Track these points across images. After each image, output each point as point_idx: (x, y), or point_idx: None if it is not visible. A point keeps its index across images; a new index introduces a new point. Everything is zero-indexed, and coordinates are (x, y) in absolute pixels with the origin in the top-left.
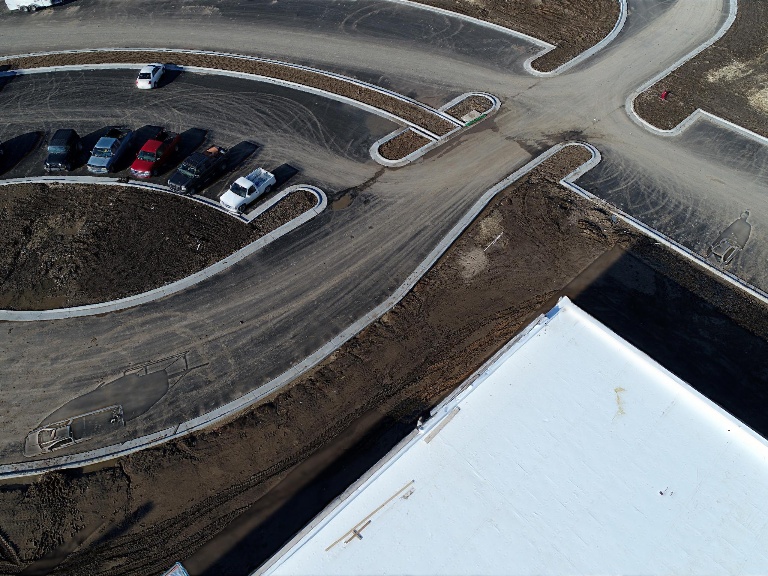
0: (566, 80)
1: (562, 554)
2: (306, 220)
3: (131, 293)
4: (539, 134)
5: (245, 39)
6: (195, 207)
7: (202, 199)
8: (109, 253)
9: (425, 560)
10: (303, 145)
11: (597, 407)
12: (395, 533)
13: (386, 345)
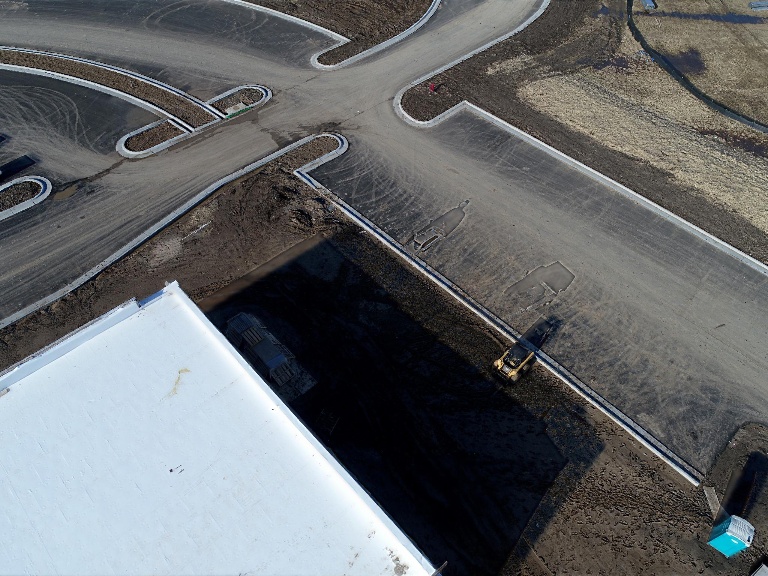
0: (347, 73)
1: (36, 530)
2: (20, 210)
3: None
4: (296, 126)
5: (41, 34)
6: None
7: None
8: None
9: None
10: (52, 137)
11: (151, 388)
12: None
13: (39, 332)
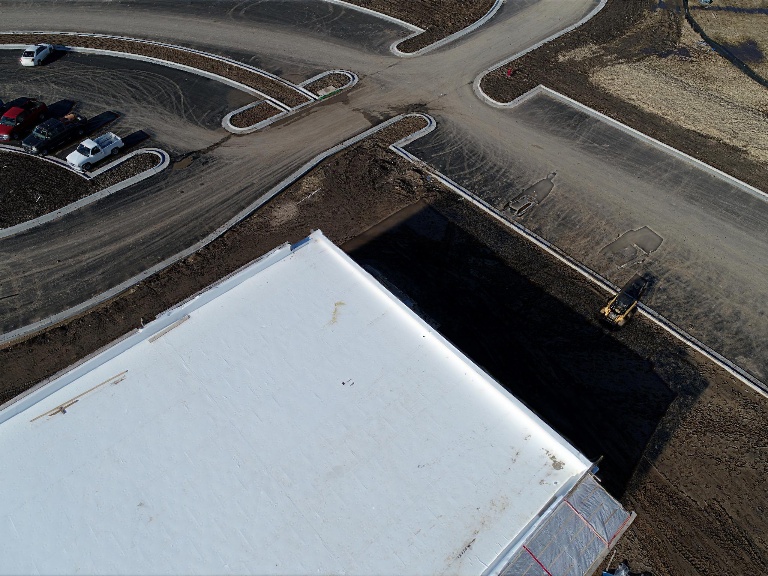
0: (426, 60)
1: (236, 428)
2: (144, 178)
3: None
4: (385, 106)
5: (136, 24)
6: (45, 166)
7: (53, 159)
8: None
9: (114, 430)
10: (162, 115)
11: (313, 317)
12: (96, 410)
13: (182, 280)
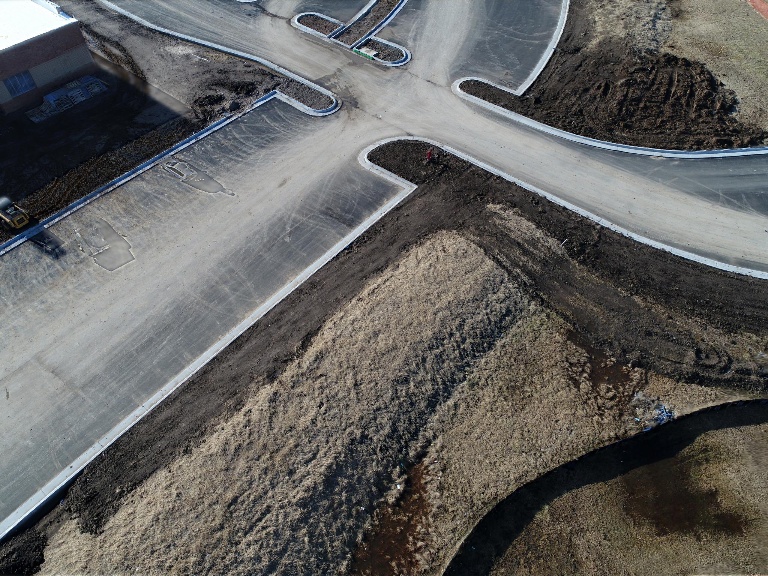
0: (451, 102)
1: None
2: None
3: None
4: (348, 84)
5: None
6: None
7: None
8: None
9: None
10: None
11: None
12: None
13: None
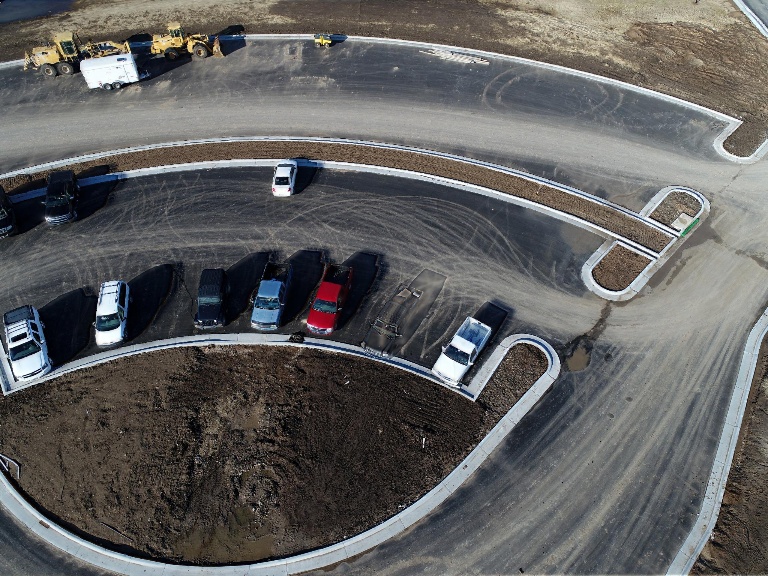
0: None
1: None
2: (544, 391)
3: (360, 527)
4: None
5: (378, 120)
6: (400, 378)
7: (405, 364)
8: (313, 460)
9: None
10: (499, 272)
11: None
12: None
13: None
